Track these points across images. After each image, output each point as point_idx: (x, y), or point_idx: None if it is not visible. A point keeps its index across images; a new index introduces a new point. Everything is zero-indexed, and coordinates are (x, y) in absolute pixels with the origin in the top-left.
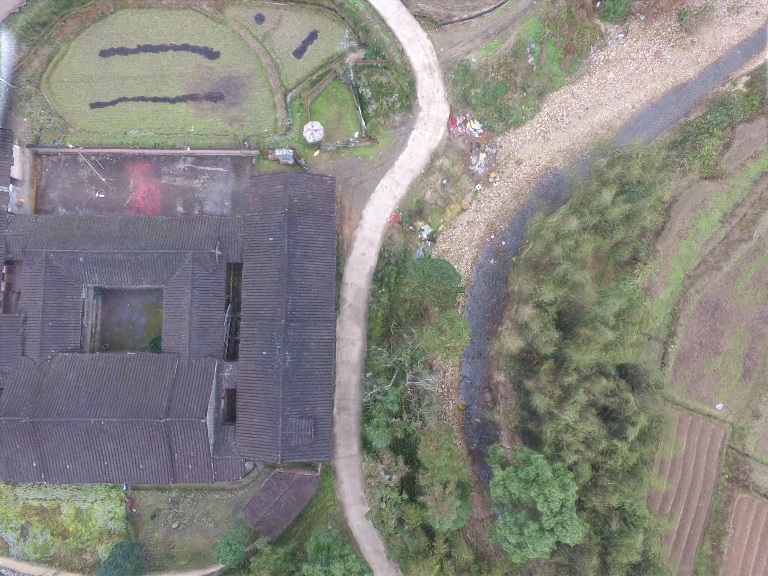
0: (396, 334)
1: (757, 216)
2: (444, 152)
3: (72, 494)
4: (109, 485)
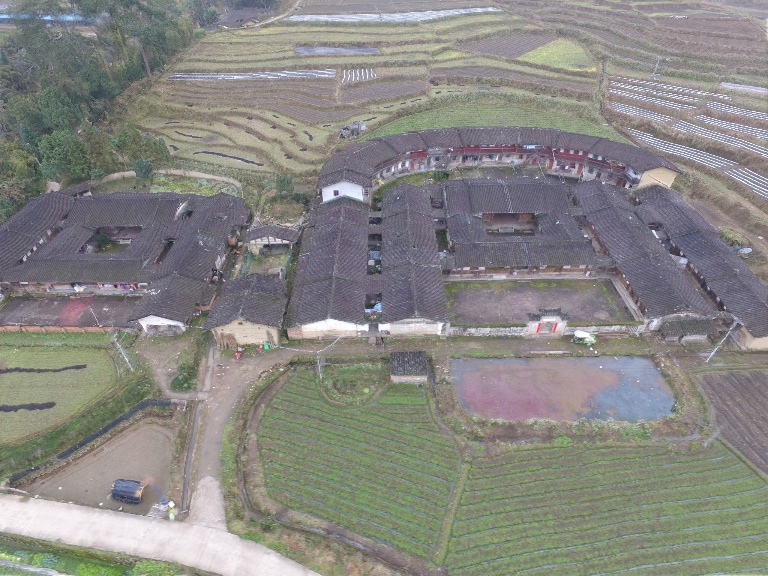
0: None
1: None
2: None
3: None
4: None
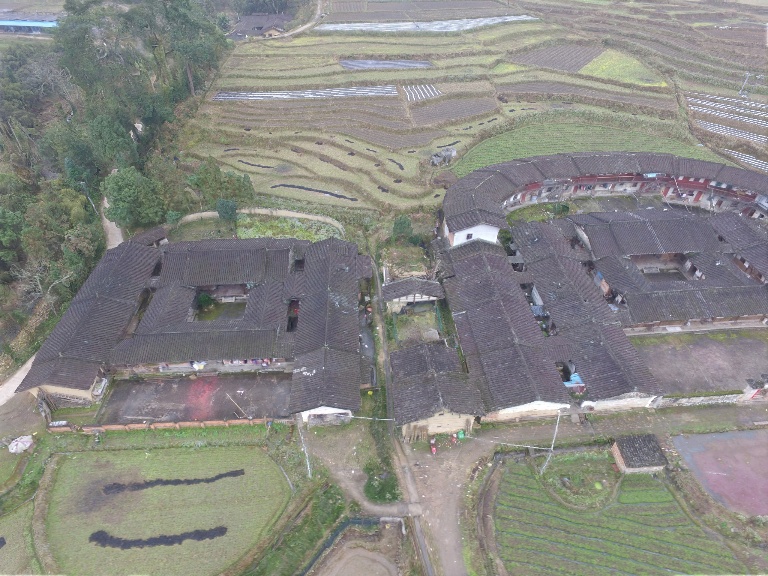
0: None
1: None
2: None
3: None
4: None
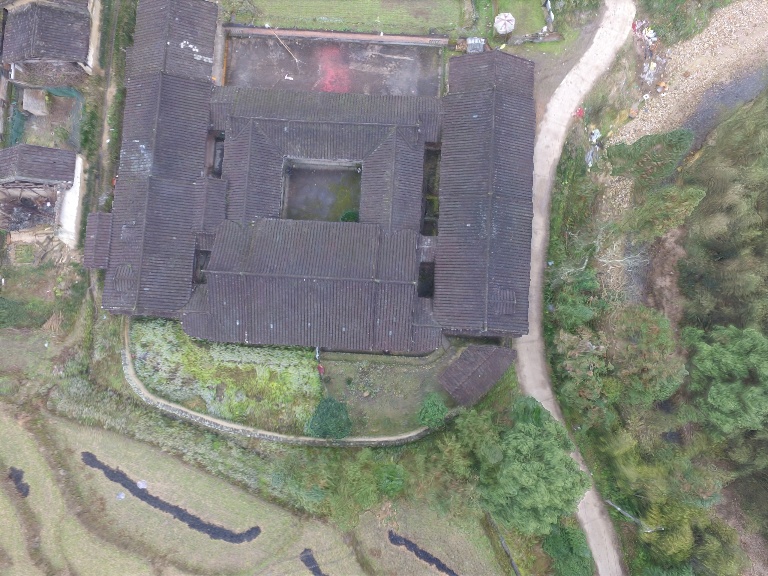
0: (570, 231)
1: None
2: (626, 53)
3: (266, 359)
4: (299, 353)
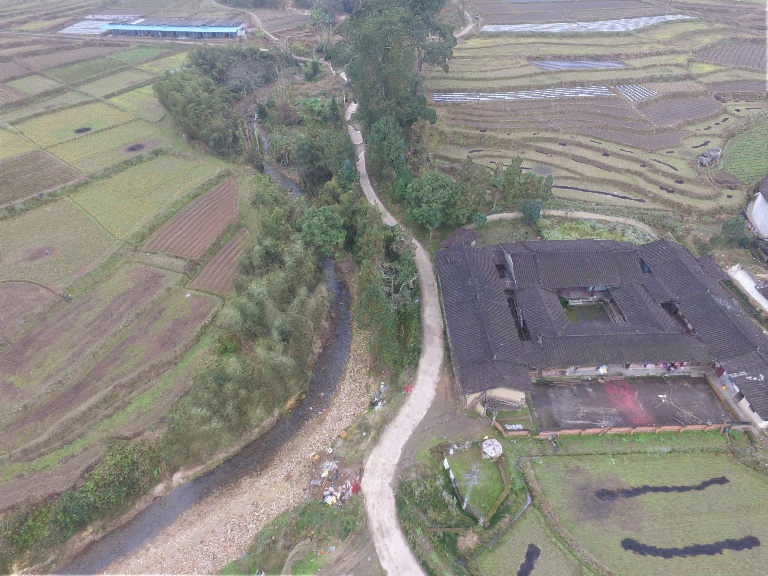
0: None
1: (100, 404)
2: None
3: None
4: None
